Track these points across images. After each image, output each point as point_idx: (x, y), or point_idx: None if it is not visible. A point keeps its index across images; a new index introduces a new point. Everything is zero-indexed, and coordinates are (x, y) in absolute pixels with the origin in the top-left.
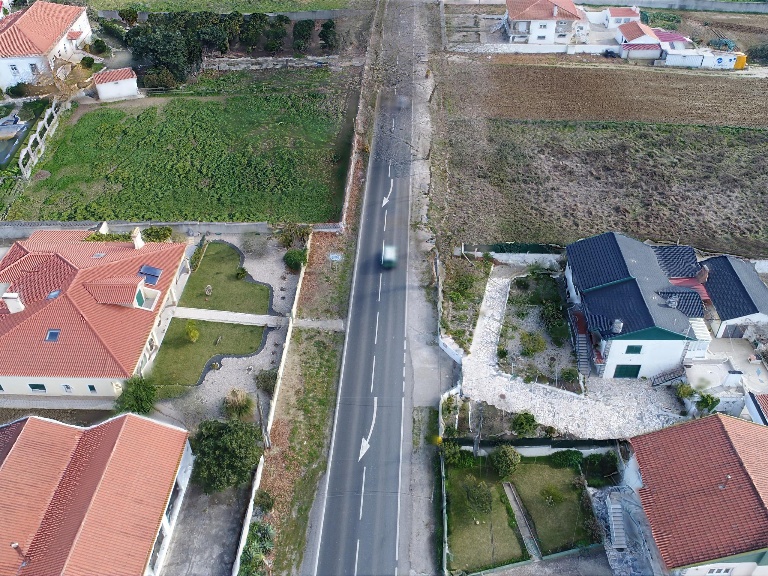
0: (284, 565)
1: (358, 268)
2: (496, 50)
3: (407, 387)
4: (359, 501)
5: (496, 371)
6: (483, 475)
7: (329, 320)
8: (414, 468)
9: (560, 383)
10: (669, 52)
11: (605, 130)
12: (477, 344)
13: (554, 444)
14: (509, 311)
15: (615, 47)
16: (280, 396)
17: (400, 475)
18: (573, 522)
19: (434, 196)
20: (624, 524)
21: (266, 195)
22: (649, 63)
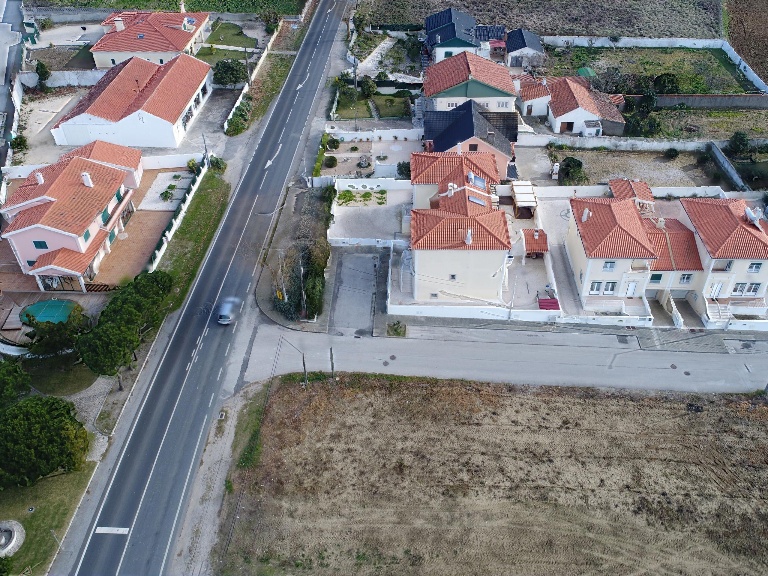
0: (256, 116)
1: (308, 34)
2: None
3: (326, 71)
4: (294, 100)
5: (376, 69)
6: (359, 97)
7: (288, 51)
8: (324, 93)
9: (409, 73)
10: None
11: None
12: (369, 60)
13: (396, 86)
14: (390, 51)
15: None
16: (259, 73)
17: (316, 94)
18: (399, 111)
19: (360, 10)
20: (421, 107)
21: (257, 8)
22: None
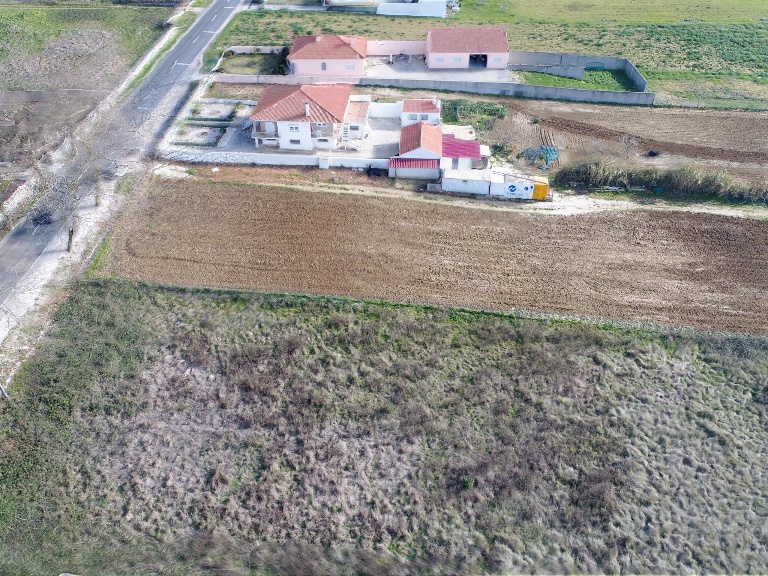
0: None
1: None
2: (226, 159)
3: None
4: None
5: None
6: None
7: None
8: None
9: None
10: (445, 174)
11: (288, 309)
12: None
13: None
14: None
15: (382, 161)
16: None
17: None
18: None
19: None
20: None
21: None
22: (420, 187)
